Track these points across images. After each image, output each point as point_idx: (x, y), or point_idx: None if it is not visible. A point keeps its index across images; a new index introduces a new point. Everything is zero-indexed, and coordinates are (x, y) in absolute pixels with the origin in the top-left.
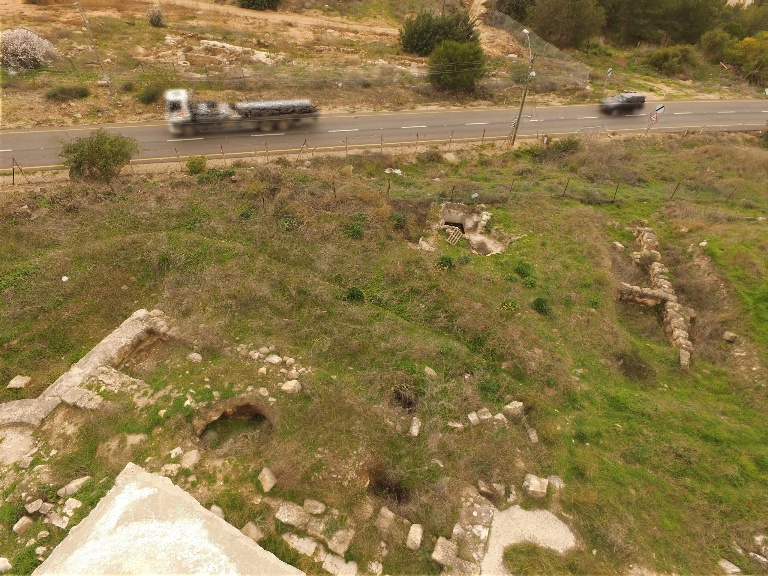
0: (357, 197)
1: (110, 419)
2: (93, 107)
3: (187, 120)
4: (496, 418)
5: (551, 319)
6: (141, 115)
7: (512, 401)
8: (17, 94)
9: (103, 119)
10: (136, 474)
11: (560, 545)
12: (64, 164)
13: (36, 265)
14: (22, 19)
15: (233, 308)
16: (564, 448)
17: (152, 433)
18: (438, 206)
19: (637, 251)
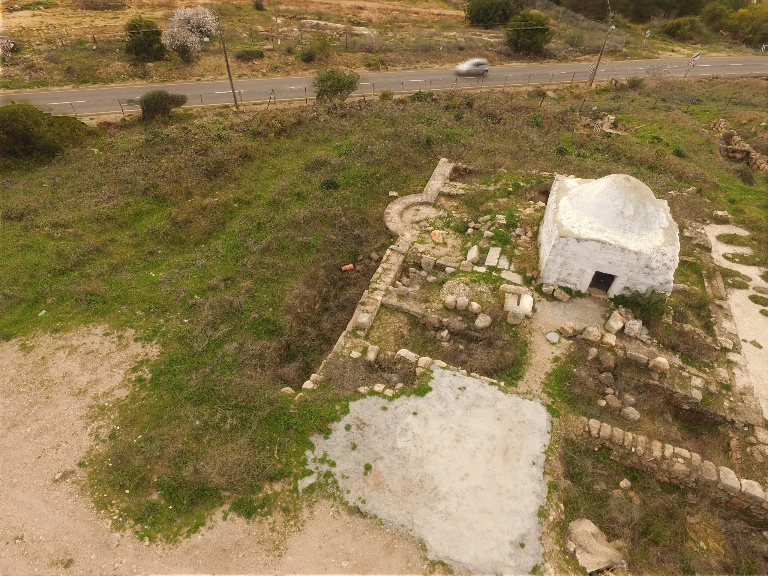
0: (524, 106)
1: (478, 196)
2: (271, 65)
3: (347, 72)
4: (683, 194)
5: (688, 159)
6: (307, 71)
7: (687, 189)
8: (211, 56)
9: (282, 73)
10: (564, 177)
11: (743, 234)
12: (324, 88)
13: (354, 141)
14: (156, 5)
15: (502, 153)
16: (725, 206)
17: (510, 197)
18: (573, 114)
19: (719, 133)
